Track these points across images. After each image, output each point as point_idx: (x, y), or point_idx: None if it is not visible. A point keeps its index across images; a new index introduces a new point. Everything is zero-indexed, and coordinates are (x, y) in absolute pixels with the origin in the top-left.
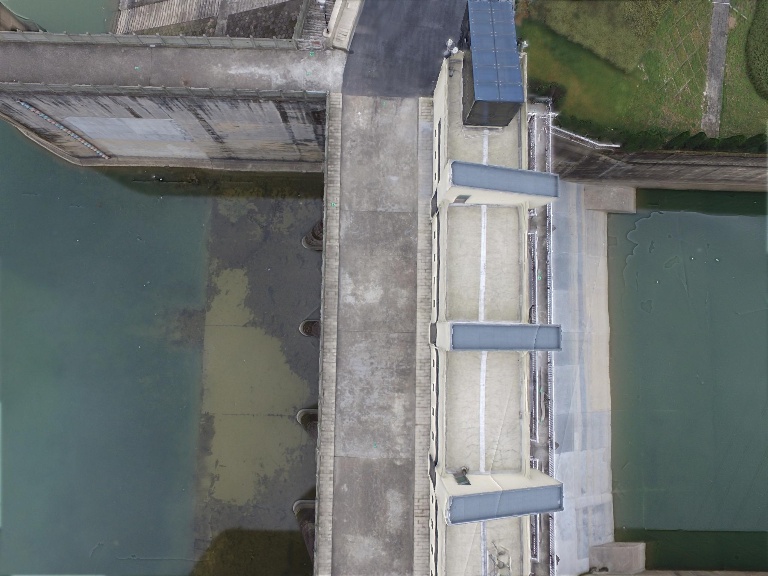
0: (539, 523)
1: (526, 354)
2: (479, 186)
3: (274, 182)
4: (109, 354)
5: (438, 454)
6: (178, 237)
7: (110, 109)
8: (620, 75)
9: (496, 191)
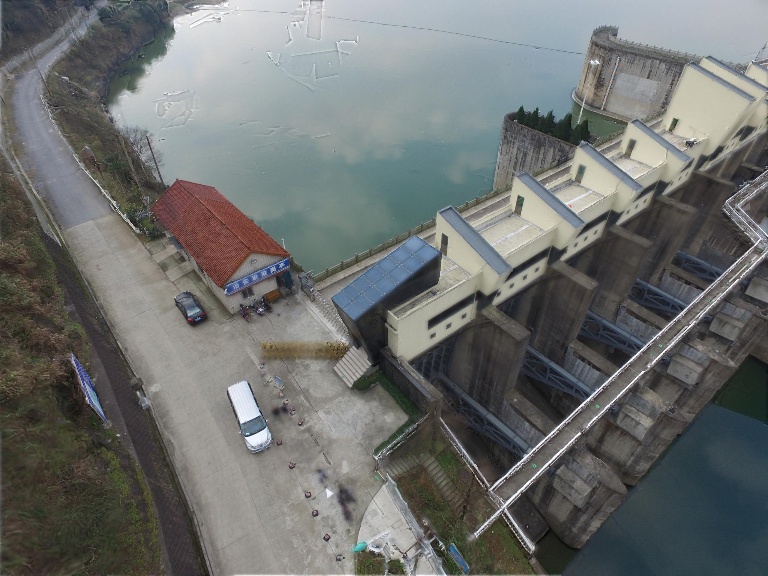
0: (760, 183)
1: None
2: None
3: None
4: None
5: None
6: None
7: (643, 70)
8: None
9: None
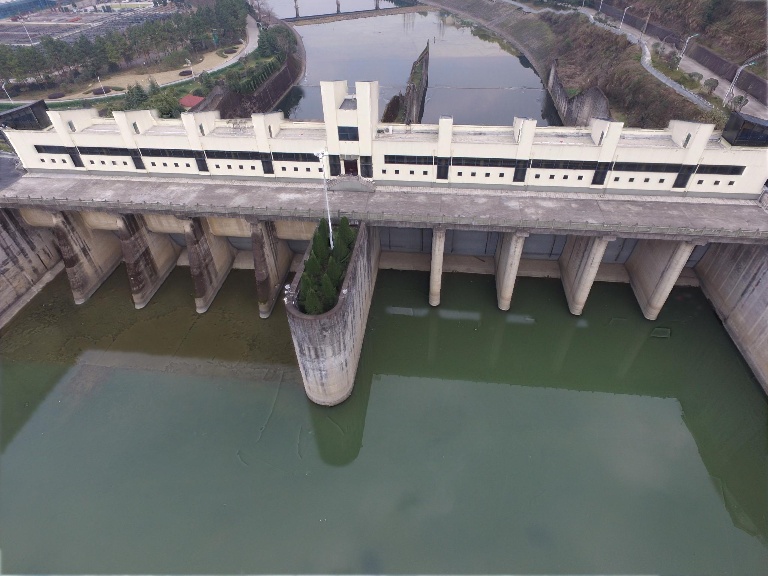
0: None
1: (153, 118)
2: None
3: (21, 318)
4: (68, 445)
5: (186, 149)
6: (7, 383)
7: None
8: None
9: (74, 110)
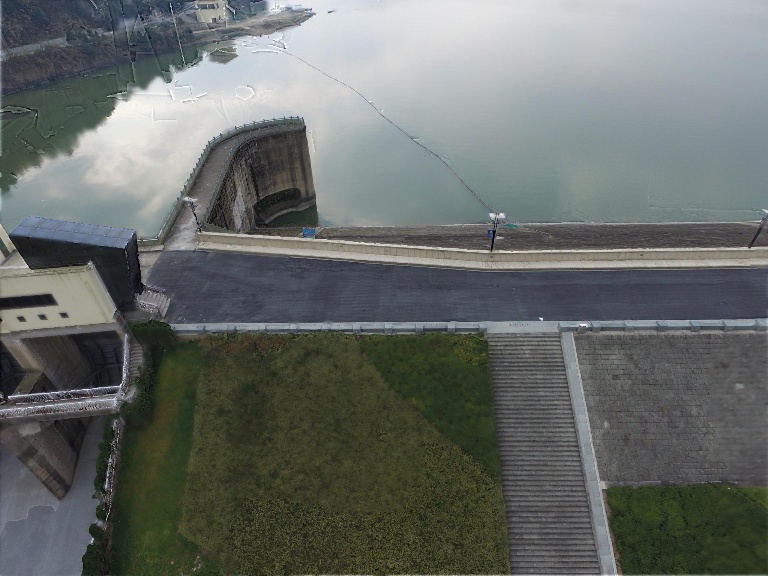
0: None
1: None
2: None
3: None
4: None
5: None
6: None
7: None
8: (180, 518)
9: None
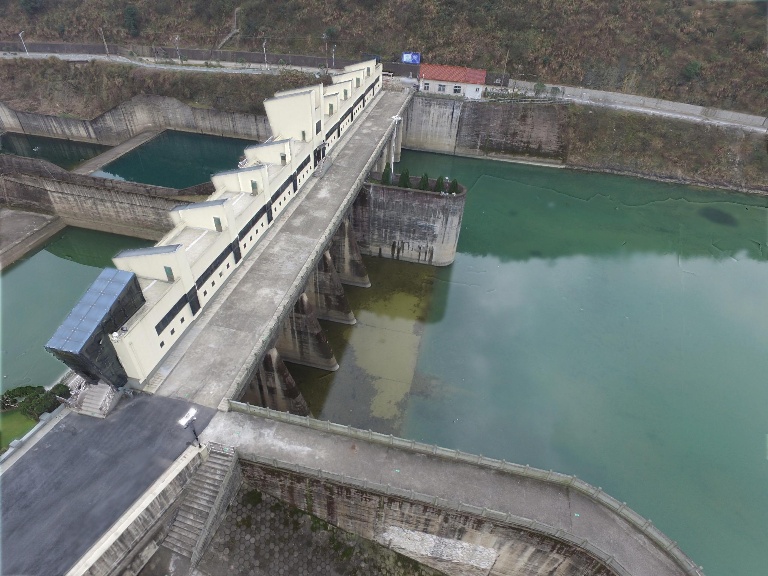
0: None
1: None
2: (166, 247)
3: None
4: (489, 383)
5: None
6: None
7: None
8: None
9: None
